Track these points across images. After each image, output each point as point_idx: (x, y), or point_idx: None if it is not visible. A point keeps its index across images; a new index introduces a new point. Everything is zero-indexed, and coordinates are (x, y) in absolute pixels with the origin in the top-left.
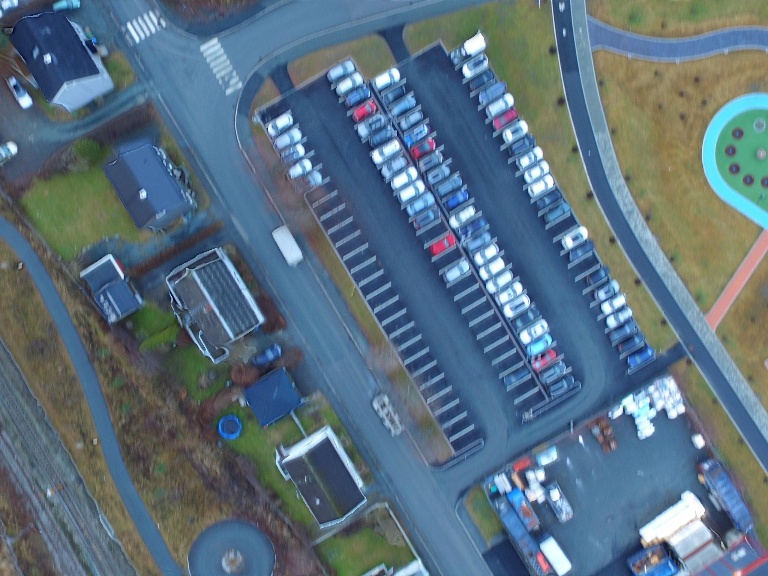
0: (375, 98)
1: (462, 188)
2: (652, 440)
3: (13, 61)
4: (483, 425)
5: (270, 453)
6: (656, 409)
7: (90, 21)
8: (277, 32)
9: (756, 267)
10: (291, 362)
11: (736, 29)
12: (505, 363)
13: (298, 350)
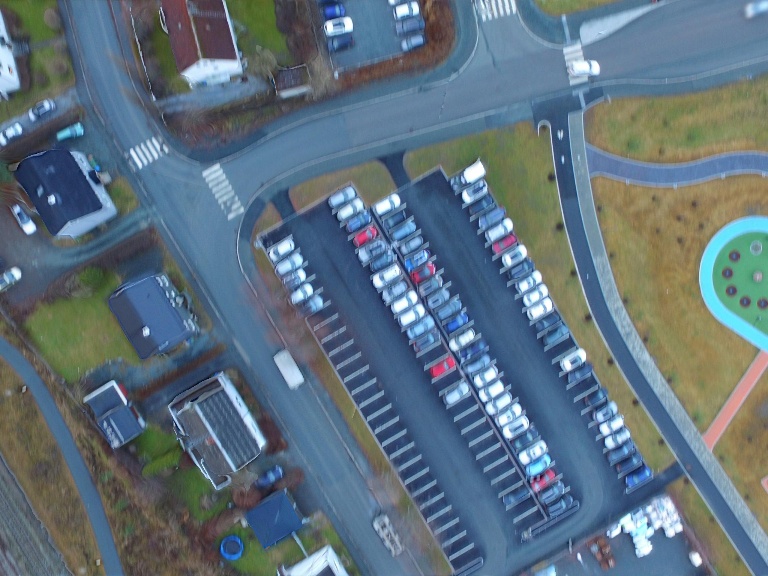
0: (376, 223)
1: (462, 311)
2: (650, 557)
3: (17, 193)
4: (482, 544)
5: (271, 572)
6: (654, 528)
7: (93, 148)
8: (279, 158)
9: (753, 387)
10: (292, 483)
11: (733, 154)
12: (504, 483)
13: (299, 471)
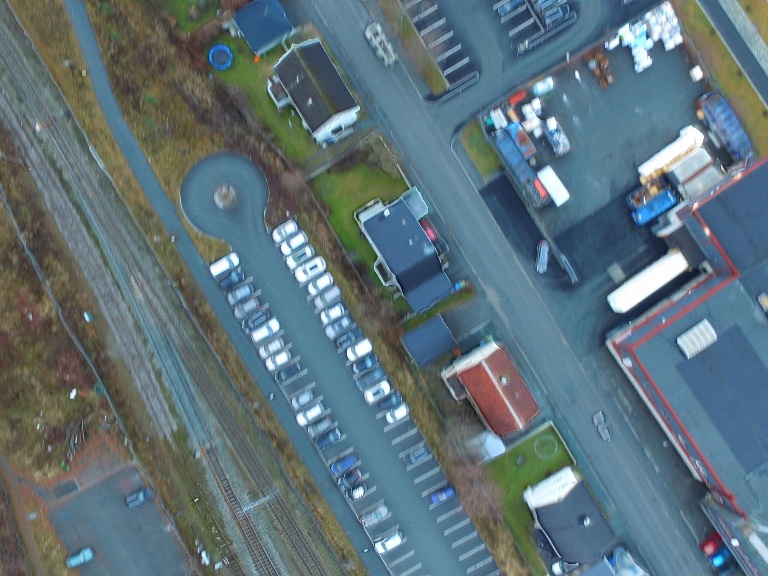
0: None
1: None
2: (649, 74)
3: None
4: (478, 58)
5: (262, 87)
6: (653, 39)
7: None
8: None
9: None
10: None
11: None
12: None
13: None
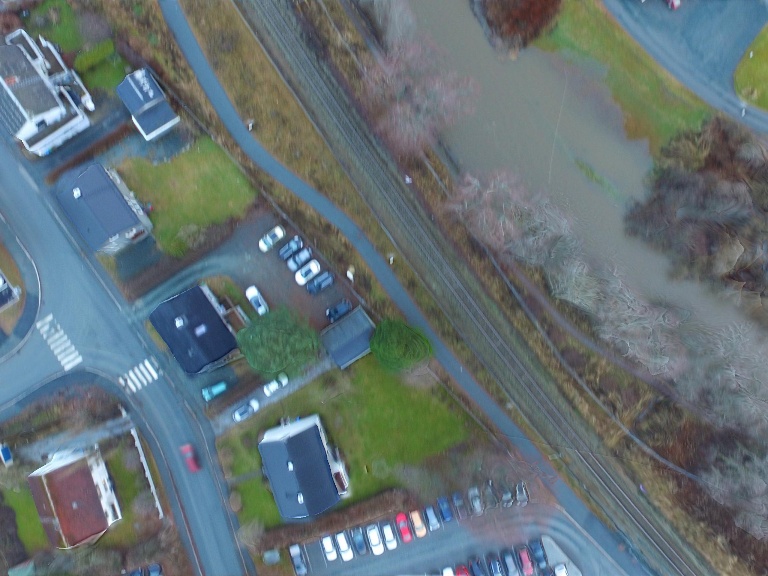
0: None
1: None
2: None
3: None
4: None
5: None
6: None
7: (193, 377)
8: (3, 381)
9: None
10: None
11: None
12: None
13: None
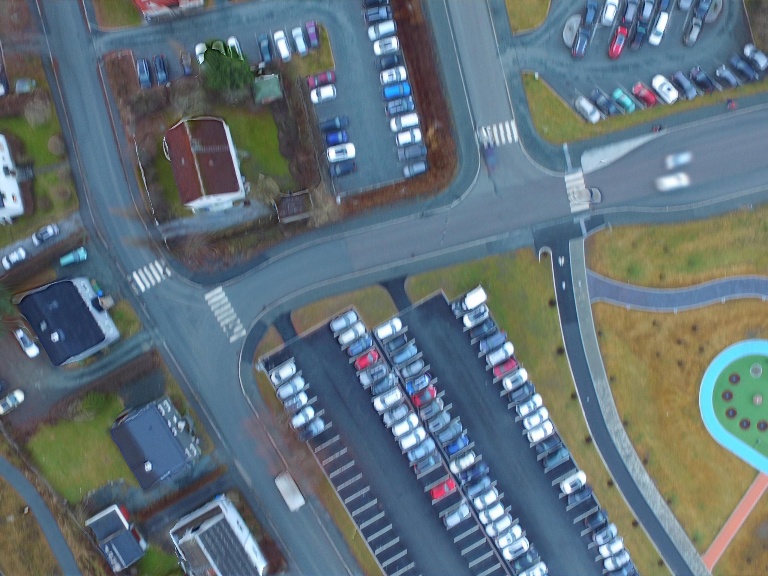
0: (377, 346)
1: (462, 434)
2: None
3: (21, 322)
4: None
5: None
6: None
7: (96, 272)
8: (281, 281)
9: (752, 509)
10: None
11: (733, 278)
12: None
13: None
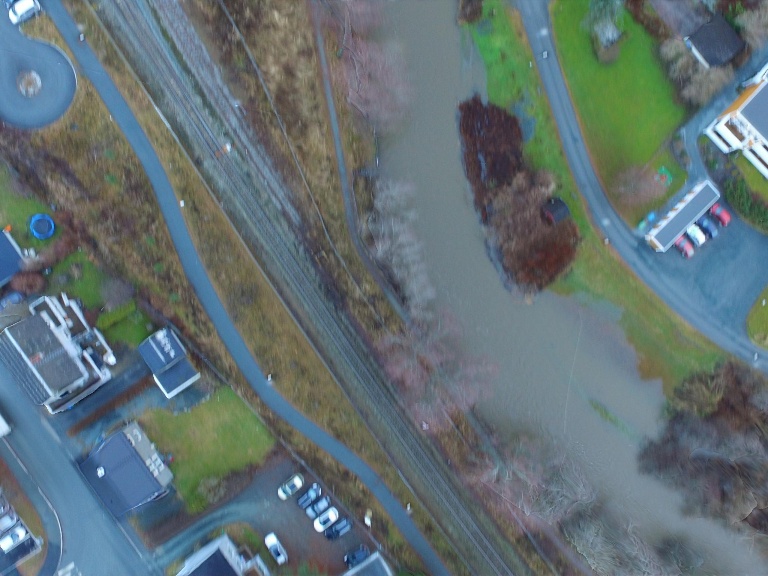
0: None
1: None
2: None
3: None
4: None
5: (3, 200)
6: None
7: None
8: None
9: None
10: None
11: None
12: None
13: None
